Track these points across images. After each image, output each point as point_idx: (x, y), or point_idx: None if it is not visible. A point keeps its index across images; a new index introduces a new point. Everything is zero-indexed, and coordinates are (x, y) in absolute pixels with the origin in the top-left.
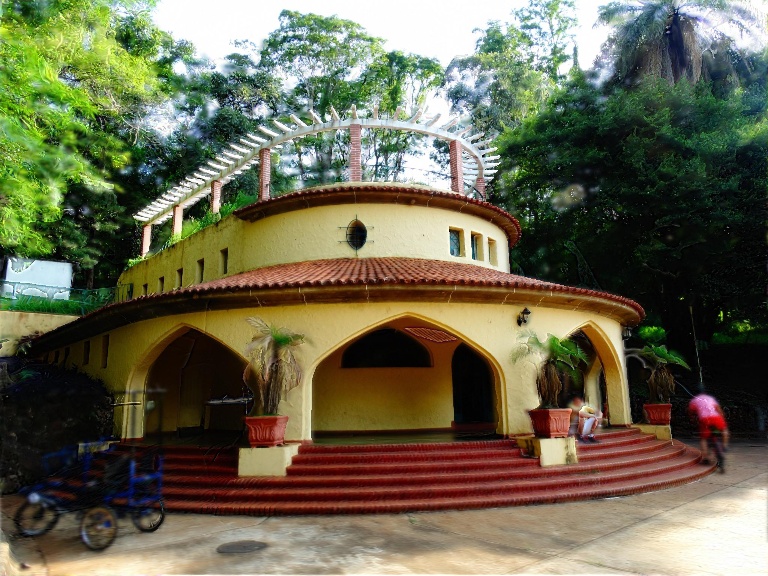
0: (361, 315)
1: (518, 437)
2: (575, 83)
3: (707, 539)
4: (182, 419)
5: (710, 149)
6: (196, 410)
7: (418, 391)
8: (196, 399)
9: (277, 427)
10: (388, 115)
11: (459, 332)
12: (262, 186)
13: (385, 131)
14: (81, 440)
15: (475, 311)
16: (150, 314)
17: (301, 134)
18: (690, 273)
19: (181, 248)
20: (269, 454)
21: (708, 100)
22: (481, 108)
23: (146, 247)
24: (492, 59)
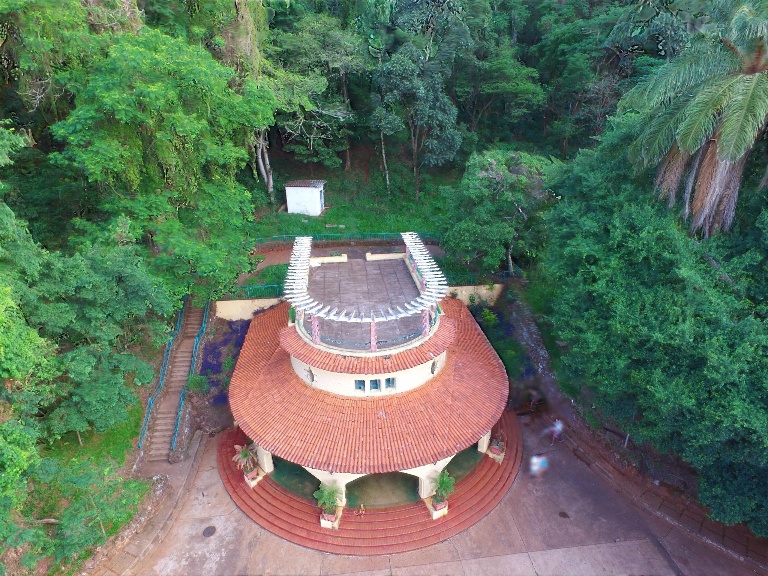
0: None
1: None
2: None
3: None
4: None
5: (615, 326)
6: None
7: None
8: None
9: (249, 476)
10: None
11: None
12: None
13: None
14: None
15: None
16: None
17: None
18: None
19: None
20: None
21: (667, 258)
22: None
23: None
24: None
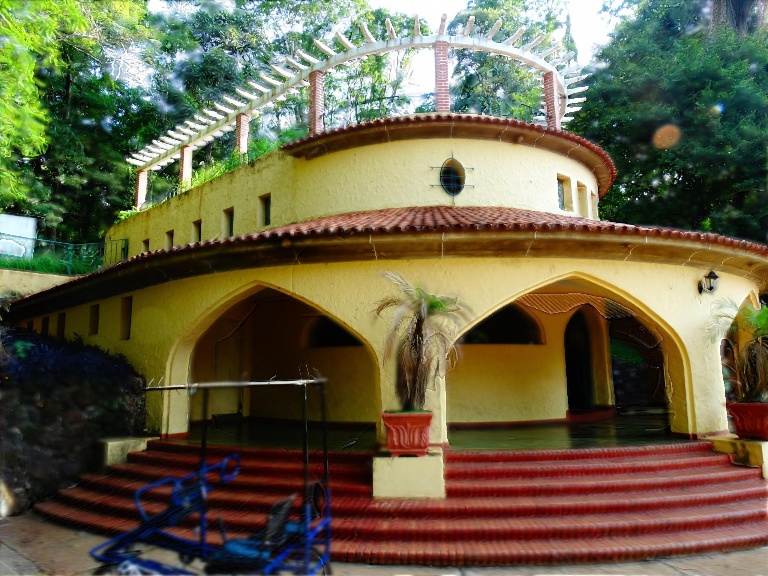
0: (517, 274)
1: (711, 437)
2: (623, 34)
3: None
4: (216, 404)
5: None
6: (232, 393)
7: (530, 374)
8: (232, 379)
9: (428, 428)
10: (371, 78)
11: (638, 300)
12: (315, 117)
13: (367, 94)
14: (107, 436)
15: (655, 273)
16: (206, 268)
17: (369, 52)
18: (766, 244)
19: (198, 195)
20: (418, 466)
21: None
22: (487, 68)
23: (142, 197)
24: (499, 16)
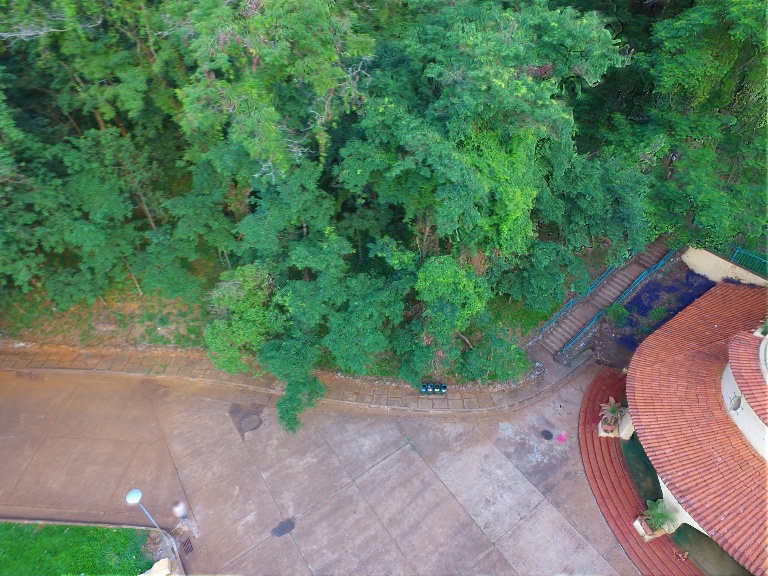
0: None
1: None
2: None
3: (563, 542)
4: None
5: None
6: None
7: None
8: None
9: (604, 426)
10: None
11: None
12: None
13: None
14: None
15: None
16: None
17: None
18: None
19: None
20: None
21: None
22: None
23: None
24: None
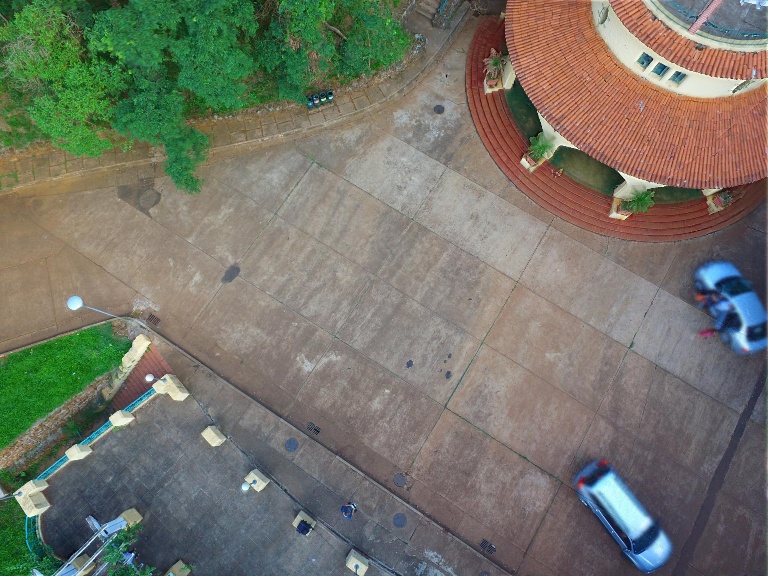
0: None
1: None
2: None
3: (467, 197)
4: None
5: None
6: None
7: None
8: None
9: (489, 82)
10: None
11: (537, 111)
12: None
13: None
14: None
15: None
16: None
17: None
18: None
19: None
20: None
21: None
22: None
23: None
24: None
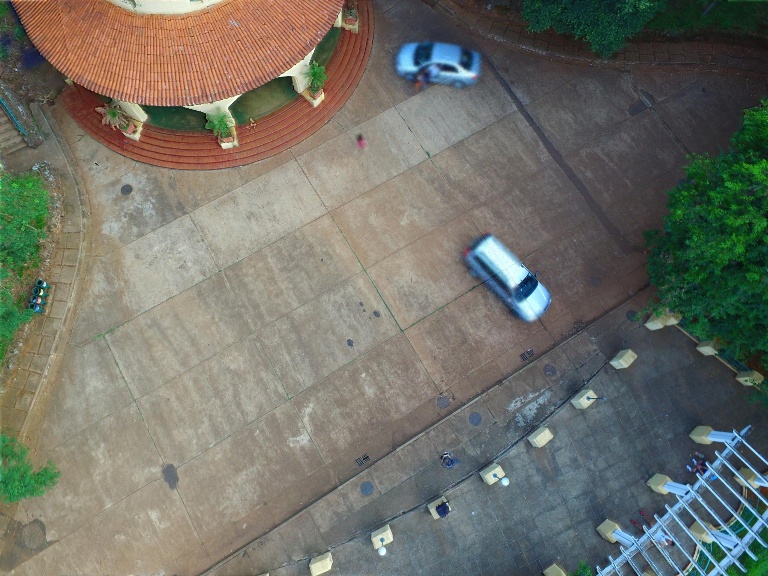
0: None
1: None
2: None
3: (228, 211)
4: None
5: None
6: None
7: None
8: None
9: None
10: None
11: None
12: None
13: None
14: None
15: None
16: None
17: None
18: None
19: None
20: None
21: None
22: None
23: None
24: None
